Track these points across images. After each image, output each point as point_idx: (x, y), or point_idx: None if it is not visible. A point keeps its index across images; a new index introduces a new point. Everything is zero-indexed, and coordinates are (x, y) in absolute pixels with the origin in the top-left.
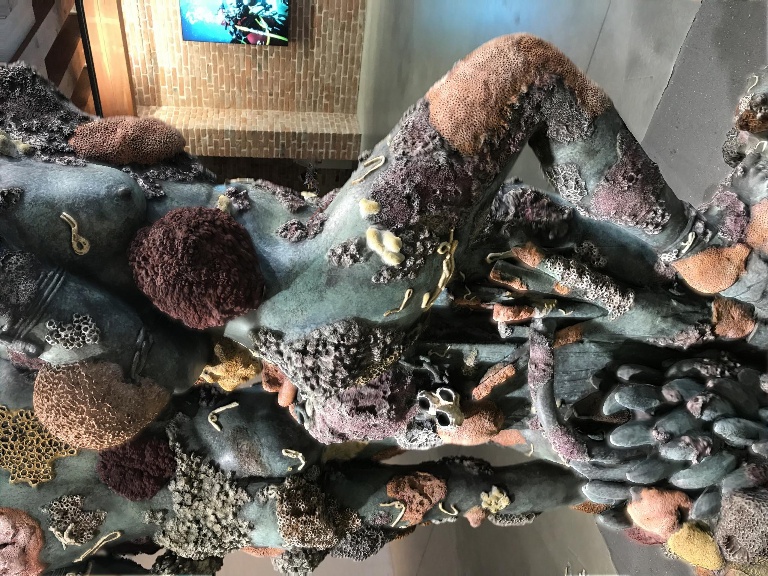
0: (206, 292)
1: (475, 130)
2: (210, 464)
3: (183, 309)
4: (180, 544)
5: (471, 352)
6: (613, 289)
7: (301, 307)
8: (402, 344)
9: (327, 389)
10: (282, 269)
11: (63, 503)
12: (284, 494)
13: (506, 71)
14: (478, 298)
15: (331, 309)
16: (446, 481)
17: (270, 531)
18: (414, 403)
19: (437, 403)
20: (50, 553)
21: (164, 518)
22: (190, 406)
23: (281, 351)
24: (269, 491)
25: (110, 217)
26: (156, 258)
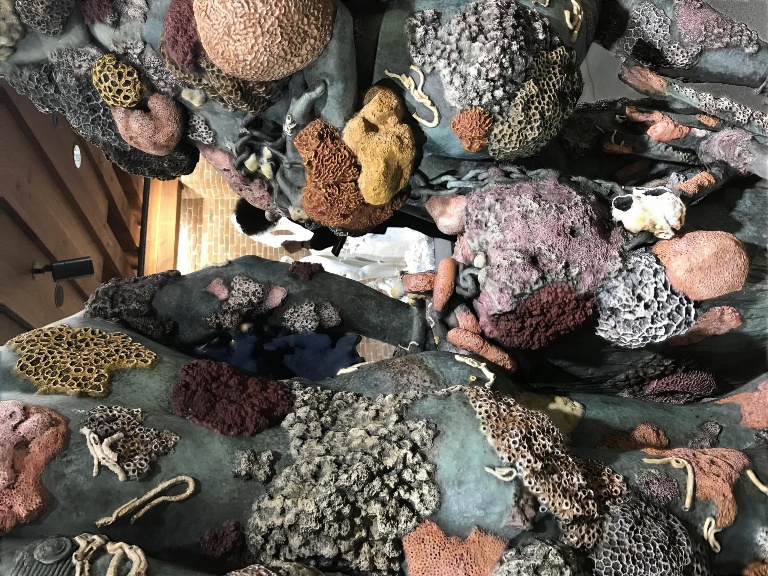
0: None
1: None
2: None
3: None
4: (303, 495)
5: None
6: (759, 112)
7: None
8: None
9: None
10: None
11: (114, 410)
12: None
13: None
14: (628, 145)
15: None
16: None
17: (467, 433)
18: (612, 227)
19: (639, 198)
20: (67, 474)
21: (273, 469)
22: None
23: None
24: None
25: None
26: None
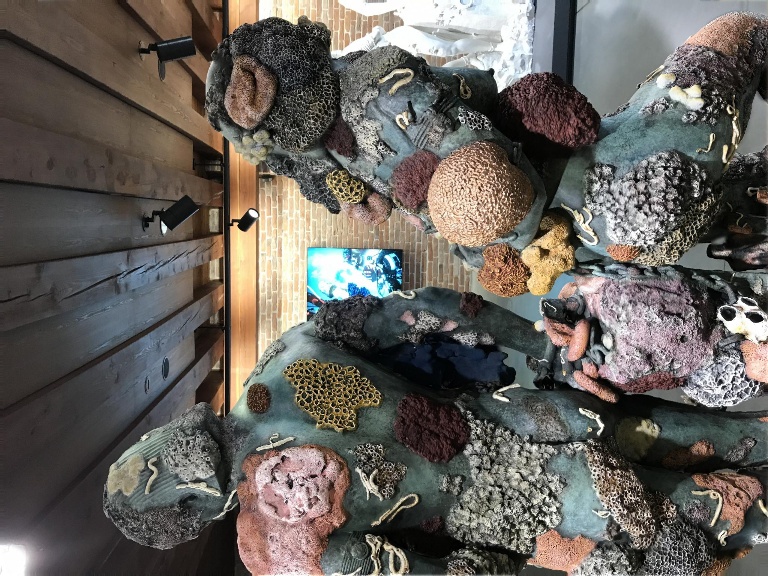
0: (567, 102)
1: (729, 41)
2: (505, 428)
3: (549, 116)
4: (482, 513)
5: (756, 280)
6: None
7: (628, 142)
8: (712, 193)
9: (659, 214)
10: (606, 123)
11: (368, 448)
12: (592, 447)
13: (738, 17)
14: (749, 226)
15: (653, 143)
16: (757, 478)
17: (584, 488)
18: (715, 325)
19: (741, 311)
20: (354, 500)
21: (461, 487)
22: (471, 392)
23: (611, 193)
24: (575, 445)
25: (484, 78)
26: (527, 84)
